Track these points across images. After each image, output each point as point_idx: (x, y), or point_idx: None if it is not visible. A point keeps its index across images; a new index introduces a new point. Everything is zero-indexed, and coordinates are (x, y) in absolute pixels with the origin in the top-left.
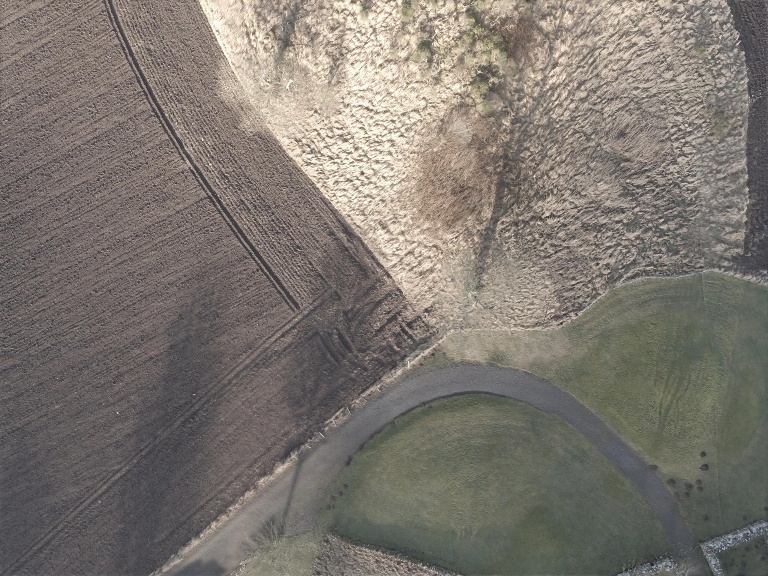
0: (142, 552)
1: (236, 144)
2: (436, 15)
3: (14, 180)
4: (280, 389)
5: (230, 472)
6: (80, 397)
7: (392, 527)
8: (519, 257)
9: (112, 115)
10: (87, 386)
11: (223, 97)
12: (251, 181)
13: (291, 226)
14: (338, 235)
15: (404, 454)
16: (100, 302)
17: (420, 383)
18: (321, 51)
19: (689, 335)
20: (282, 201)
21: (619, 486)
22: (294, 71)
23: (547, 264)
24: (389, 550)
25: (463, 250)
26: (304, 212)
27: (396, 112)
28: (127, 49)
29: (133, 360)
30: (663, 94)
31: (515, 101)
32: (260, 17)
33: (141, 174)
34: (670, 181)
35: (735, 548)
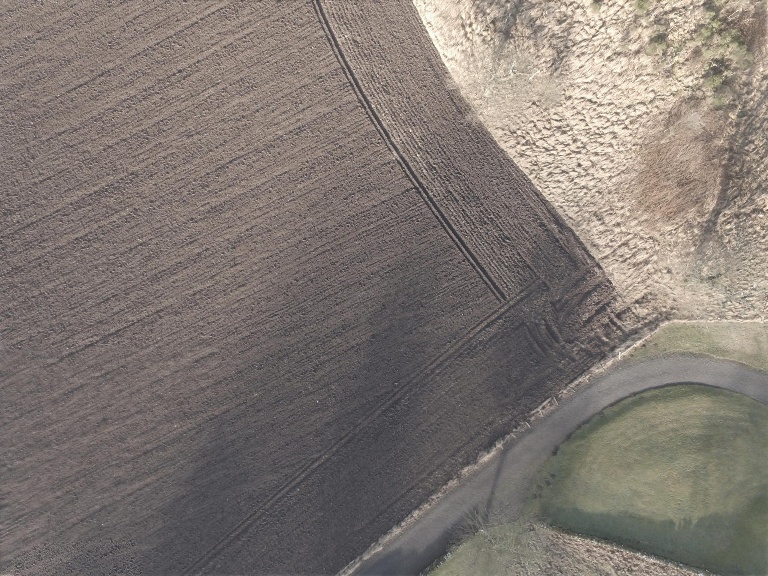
0: (341, 540)
1: (446, 135)
2: (671, 8)
3: (213, 169)
4: (485, 379)
5: (432, 461)
6: (279, 385)
7: (604, 517)
8: (739, 249)
9: (316, 106)
10: (287, 374)
11: (433, 89)
12: (460, 172)
13: (500, 217)
14: (549, 226)
15: (615, 444)
16: (301, 291)
17: (630, 374)
18: (545, 43)
19: None
20: (492, 192)
21: None
22: None
23: (767, 256)
24: (603, 539)
25: (681, 242)
26: (514, 203)
27: (621, 104)
28: (333, 40)
29: (334, 349)
30: None
31: (744, 94)
32: (478, 9)
33: (346, 164)
34: None
35: None
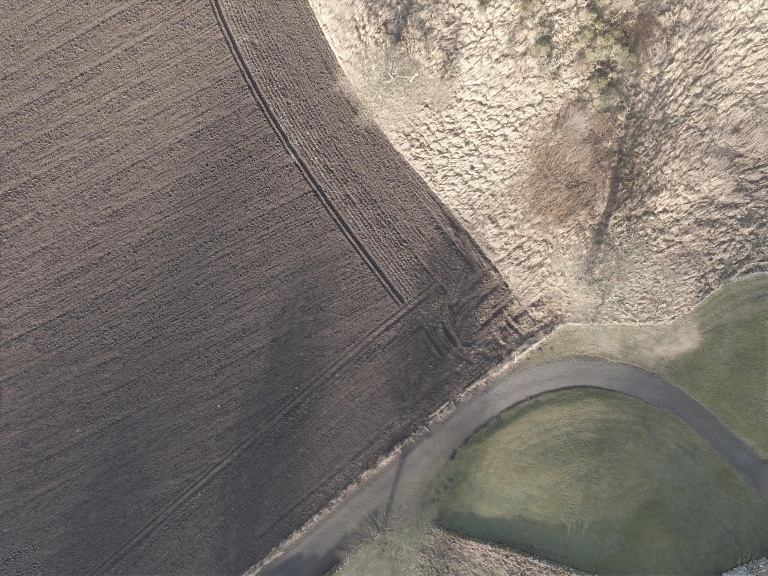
0: (243, 545)
1: (342, 138)
2: (555, 10)
3: (115, 173)
4: (384, 383)
5: (332, 465)
6: (181, 390)
7: (499, 521)
8: (631, 252)
9: (216, 109)
10: (188, 379)
11: (329, 91)
12: (357, 175)
13: (397, 220)
14: (445, 229)
15: (511, 448)
16: (202, 295)
17: (527, 377)
18: (435, 45)
19: None
20: (388, 195)
21: (732, 480)
22: (405, 65)
23: (659, 259)
24: (497, 544)
25: (574, 245)
26: (411, 206)
27: (510, 107)
28: (231, 43)
29: (235, 353)
30: None
31: (631, 96)
32: (371, 11)
33: (245, 168)
34: None
35: None
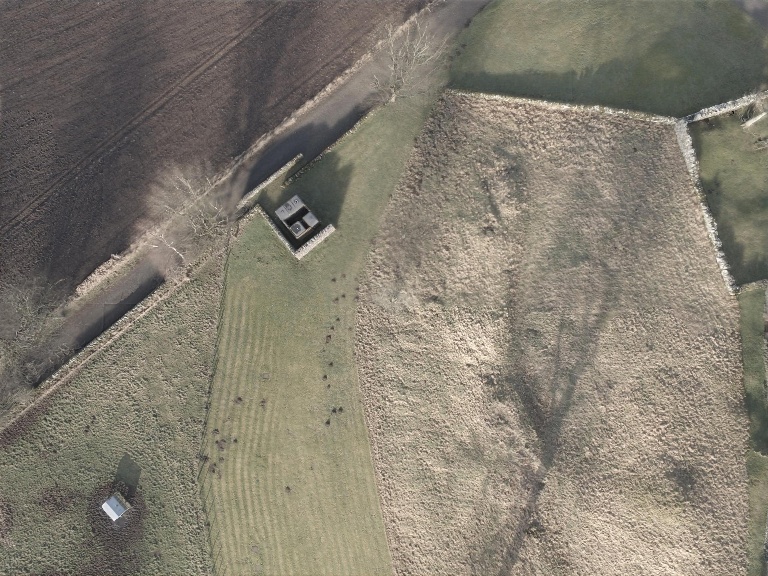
0: (255, 116)
1: None
2: None
3: None
4: None
5: (348, 38)
6: None
7: (510, 77)
8: None
9: None
10: None
11: None
12: None
13: None
14: None
15: (525, 9)
16: None
17: None
18: None
19: None
20: None
21: (742, 24)
22: None
23: None
24: None
25: None
26: None
27: None
28: None
29: None
30: None
31: None
32: None
33: None
34: None
35: None
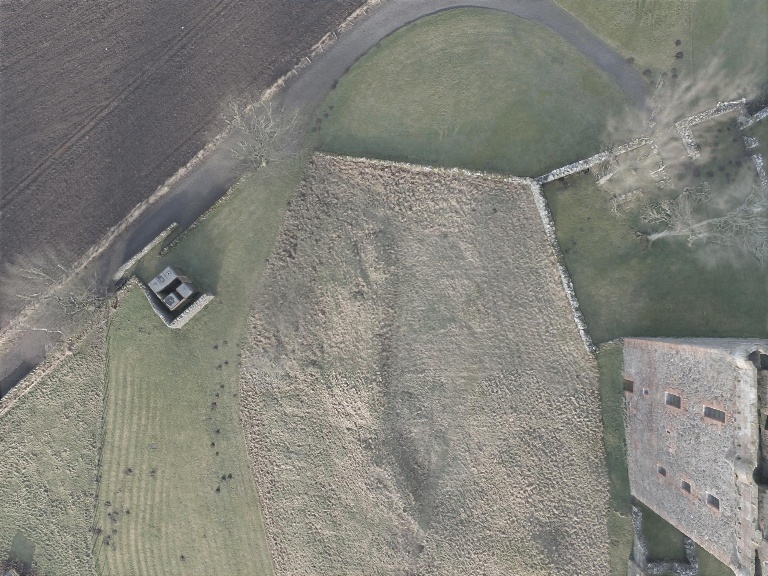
0: (129, 185)
1: None
2: None
3: None
4: (268, 18)
5: (217, 103)
6: (69, 34)
7: (376, 138)
8: None
9: None
10: (76, 22)
11: None
12: None
13: None
14: None
15: (389, 69)
16: None
17: (405, 3)
18: None
19: None
20: None
21: (597, 79)
22: None
23: None
24: None
25: None
26: None
27: None
28: None
29: None
30: None
31: None
32: None
33: None
34: None
35: (708, 130)
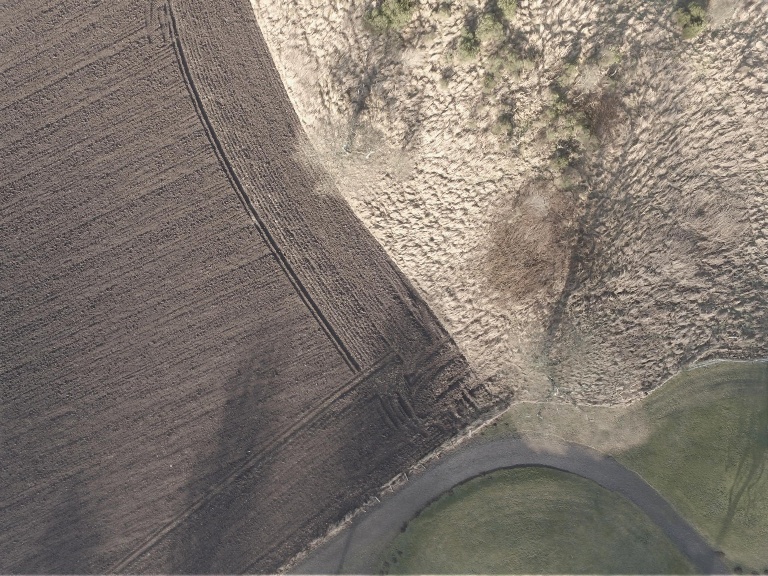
0: None
1: (303, 202)
2: (518, 88)
3: (77, 226)
4: (337, 450)
5: (282, 532)
6: (134, 448)
7: None
8: (589, 332)
9: (179, 166)
10: (141, 437)
11: (292, 154)
12: (317, 240)
13: (355, 287)
14: (403, 299)
15: (462, 525)
16: (158, 353)
17: (481, 453)
18: (397, 116)
19: (763, 422)
20: (348, 262)
21: (684, 572)
22: (367, 134)
23: (618, 340)
24: None
25: (532, 322)
26: (370, 274)
27: (471, 181)
28: (197, 101)
29: (189, 413)
30: (744, 174)
31: (593, 176)
32: (335, 78)
33: (205, 227)
34: (748, 262)
35: None
